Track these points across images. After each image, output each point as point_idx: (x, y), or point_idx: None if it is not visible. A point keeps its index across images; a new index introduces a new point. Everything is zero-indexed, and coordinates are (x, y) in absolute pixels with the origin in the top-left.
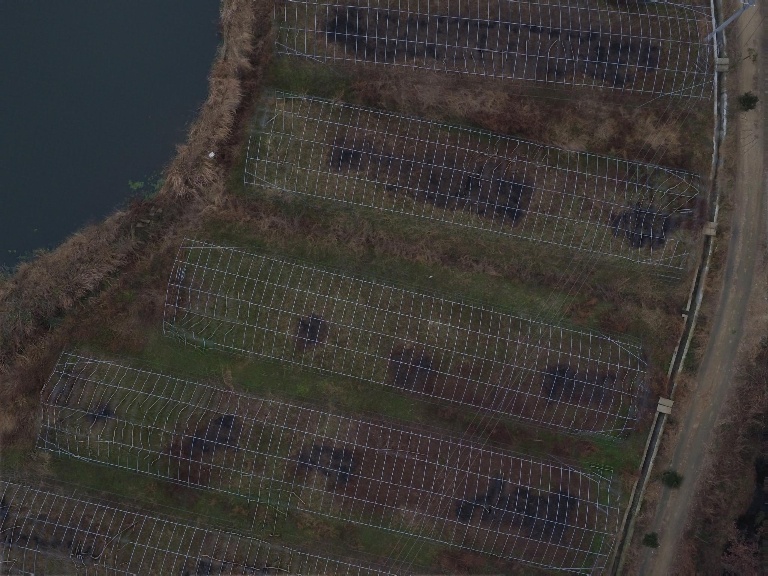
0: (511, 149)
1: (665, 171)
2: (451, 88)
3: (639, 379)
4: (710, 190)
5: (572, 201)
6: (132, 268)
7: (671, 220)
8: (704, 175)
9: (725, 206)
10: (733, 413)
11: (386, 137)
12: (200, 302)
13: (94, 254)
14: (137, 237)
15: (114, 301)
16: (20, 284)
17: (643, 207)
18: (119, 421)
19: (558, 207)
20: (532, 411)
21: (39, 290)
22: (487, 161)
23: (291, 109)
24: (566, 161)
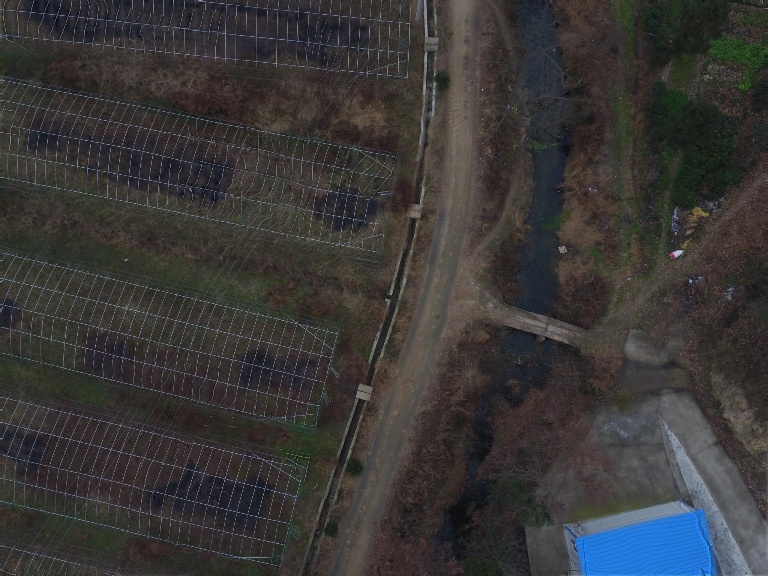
0: (201, 129)
1: (358, 152)
2: (147, 68)
3: (324, 364)
4: (416, 172)
5: (274, 183)
6: None
7: (374, 202)
8: (405, 156)
9: (431, 188)
10: (433, 400)
11: (3, 113)
12: None
13: None
14: None
15: None
16: None
17: (342, 189)
18: None
19: (259, 189)
20: (210, 396)
21: None
22: (188, 142)
23: None
24: (264, 142)
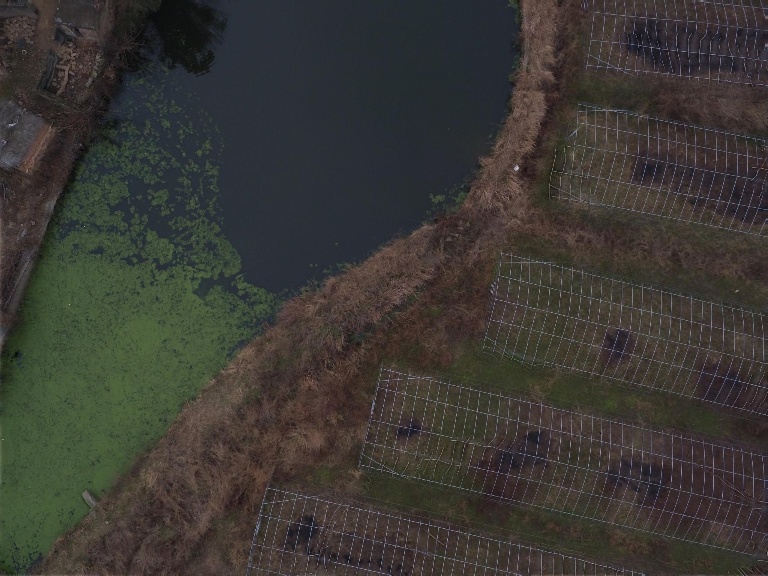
0: None
1: None
2: (759, 102)
3: None
4: None
5: None
6: (439, 282)
7: None
8: None
9: None
10: None
11: None
12: (634, 319)
13: (405, 268)
14: (445, 251)
15: (421, 316)
16: (329, 299)
17: None
18: (706, 444)
19: None
20: None
21: (349, 305)
22: None
23: (595, 122)
24: None
